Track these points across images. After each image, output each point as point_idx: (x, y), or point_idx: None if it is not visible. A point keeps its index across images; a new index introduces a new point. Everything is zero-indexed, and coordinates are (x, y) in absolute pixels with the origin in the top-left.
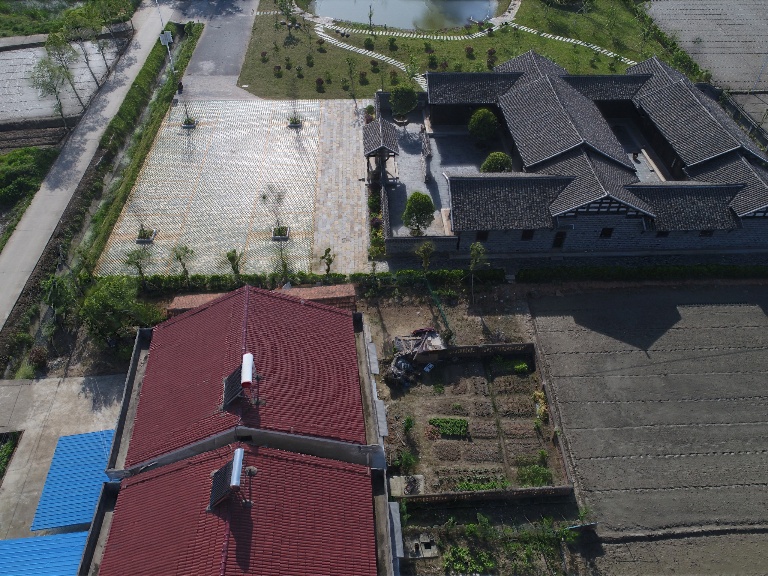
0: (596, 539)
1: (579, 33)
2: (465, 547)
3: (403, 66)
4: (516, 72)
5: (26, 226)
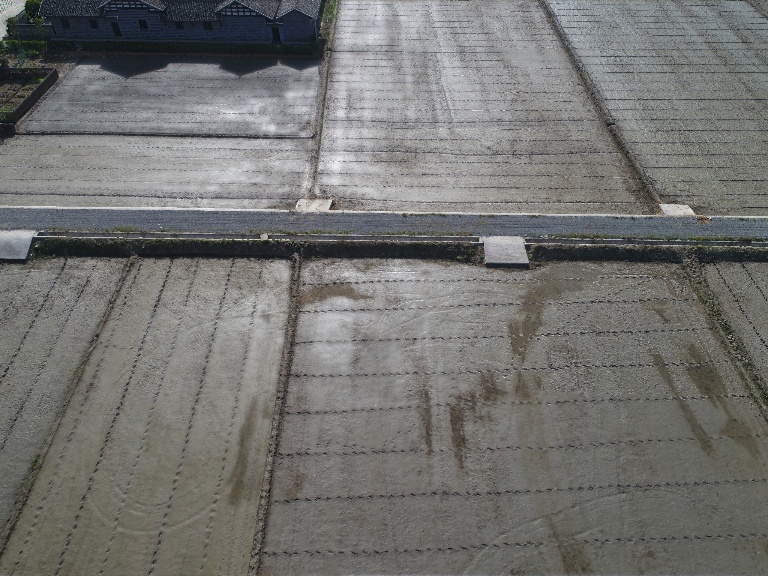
0: (13, 133)
1: None
2: None
3: None
4: None
5: None
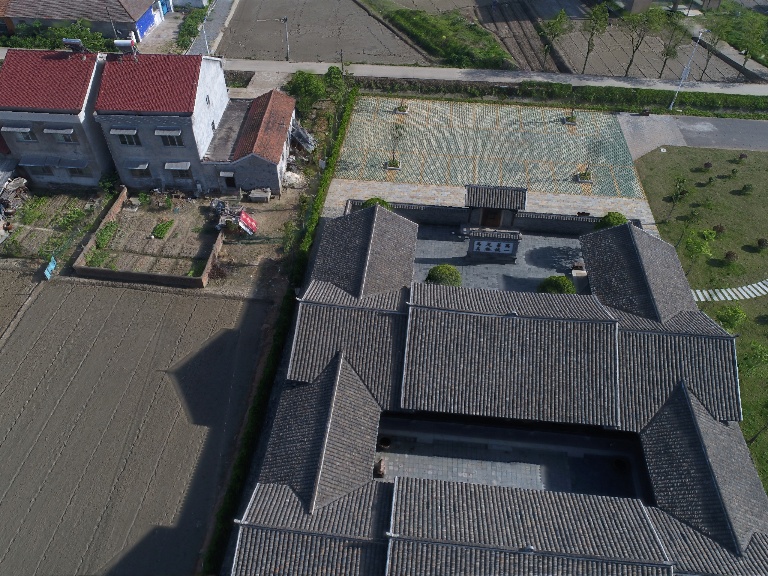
0: None
1: None
2: None
3: None
4: (658, 313)
5: (419, 69)
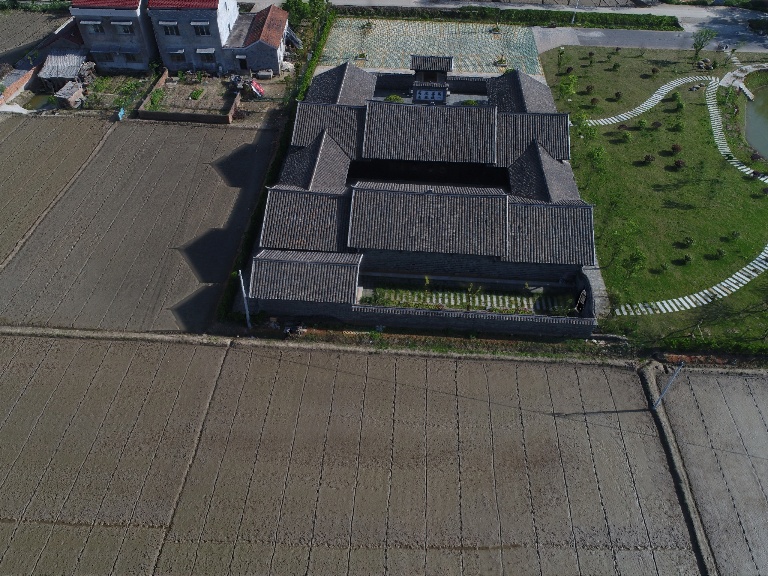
0: None
1: None
2: None
3: (629, 115)
4: None
5: (383, 0)
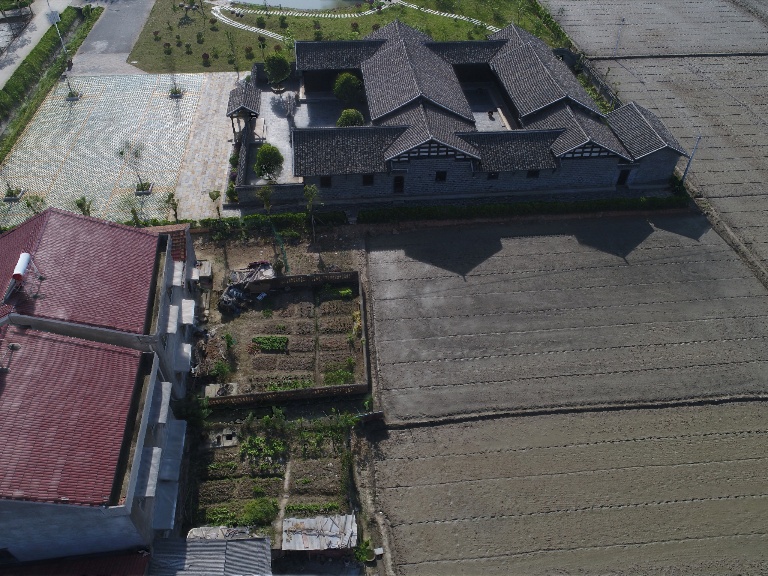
0: (383, 426)
1: (463, 9)
2: (263, 437)
3: None
4: (380, 39)
5: None
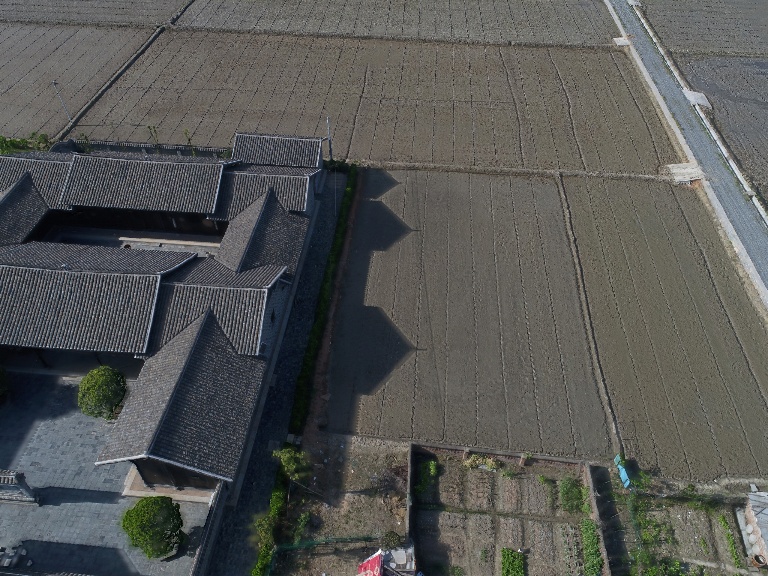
0: None
1: None
2: None
3: None
4: None
5: None
